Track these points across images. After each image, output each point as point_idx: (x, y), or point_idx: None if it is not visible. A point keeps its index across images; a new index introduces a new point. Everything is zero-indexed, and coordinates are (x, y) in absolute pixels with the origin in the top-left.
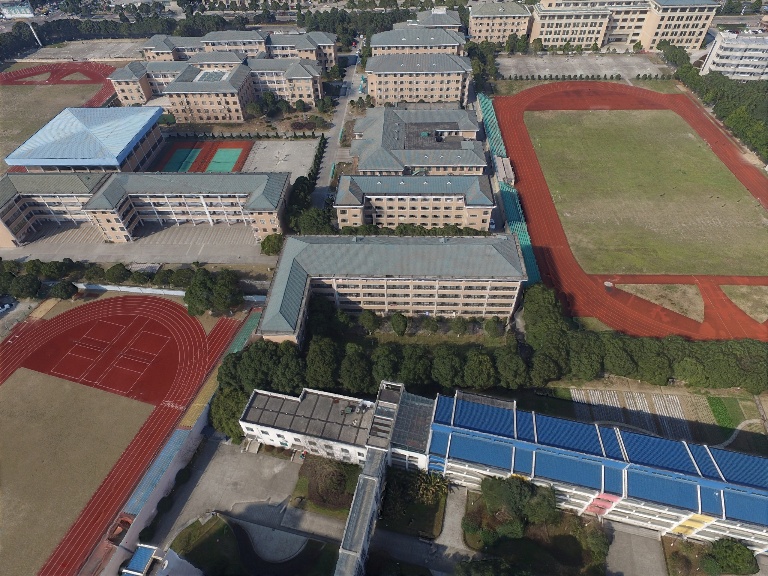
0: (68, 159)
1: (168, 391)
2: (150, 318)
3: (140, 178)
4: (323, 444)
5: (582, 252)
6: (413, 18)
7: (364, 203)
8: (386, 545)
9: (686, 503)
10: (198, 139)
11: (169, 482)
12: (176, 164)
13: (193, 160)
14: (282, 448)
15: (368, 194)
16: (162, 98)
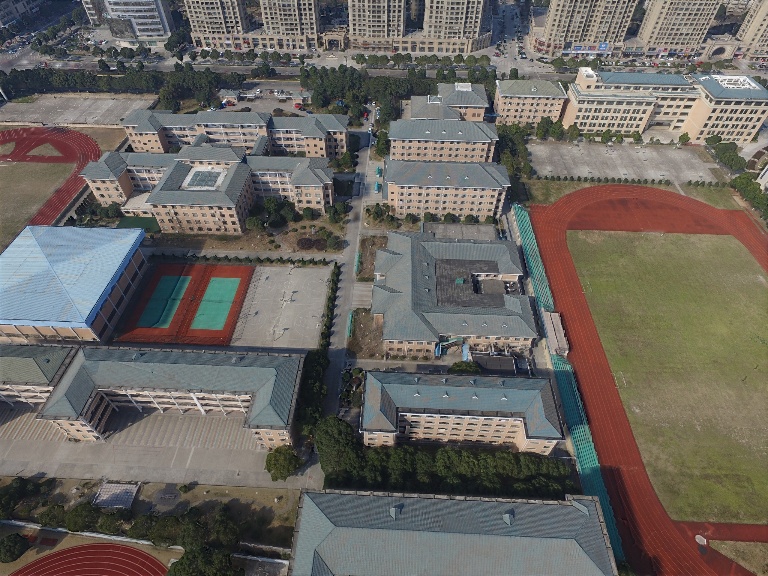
0: (24, 321)
1: None
2: None
3: (114, 366)
4: None
5: (661, 479)
6: (432, 86)
7: None
8: None
9: None
10: (187, 260)
11: None
12: (160, 302)
13: (181, 296)
14: None
15: (403, 409)
16: (145, 195)
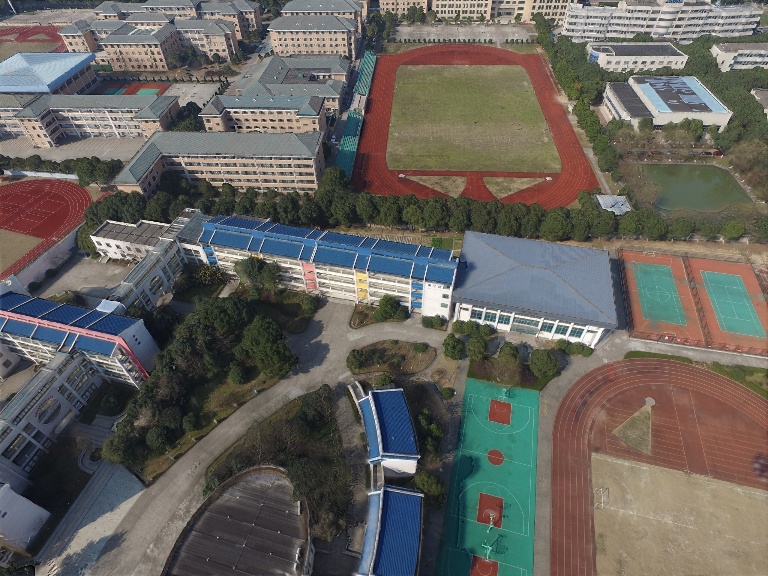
0: (10, 86)
1: (55, 232)
2: (55, 192)
3: (60, 97)
4: (144, 249)
5: (393, 157)
6: None
7: (224, 114)
8: (174, 307)
9: (347, 263)
10: (127, 82)
11: (39, 273)
12: None
13: None
14: (123, 260)
15: (228, 108)
16: (104, 52)
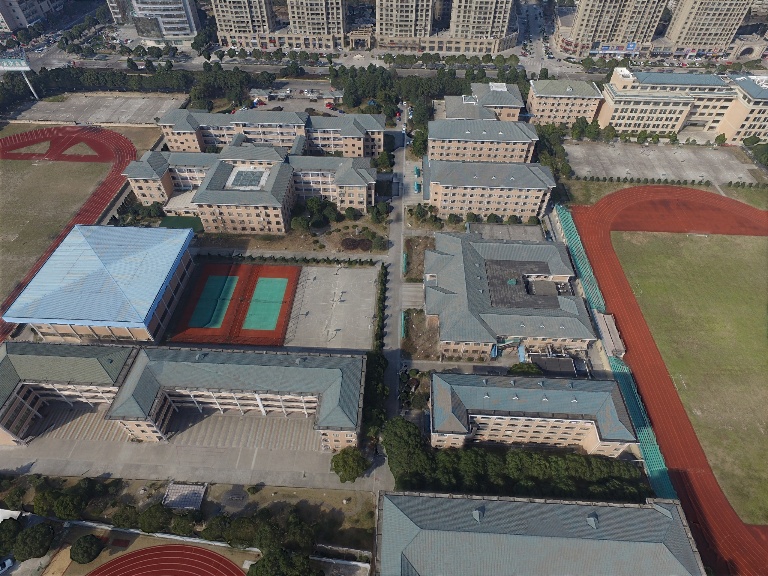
0: (83, 321)
1: None
2: None
3: (178, 366)
4: None
5: (729, 482)
6: (464, 86)
7: None
8: None
9: None
10: (233, 260)
11: None
12: (210, 302)
13: (230, 296)
14: None
15: (473, 411)
16: (186, 195)
